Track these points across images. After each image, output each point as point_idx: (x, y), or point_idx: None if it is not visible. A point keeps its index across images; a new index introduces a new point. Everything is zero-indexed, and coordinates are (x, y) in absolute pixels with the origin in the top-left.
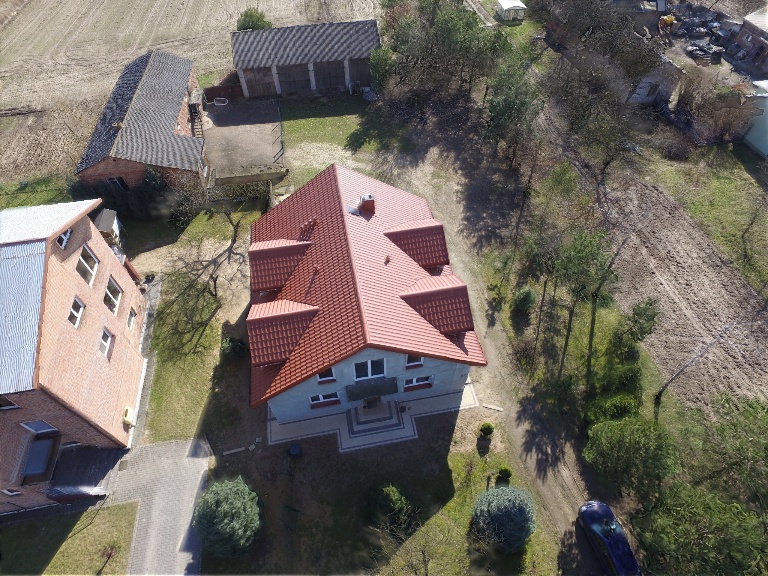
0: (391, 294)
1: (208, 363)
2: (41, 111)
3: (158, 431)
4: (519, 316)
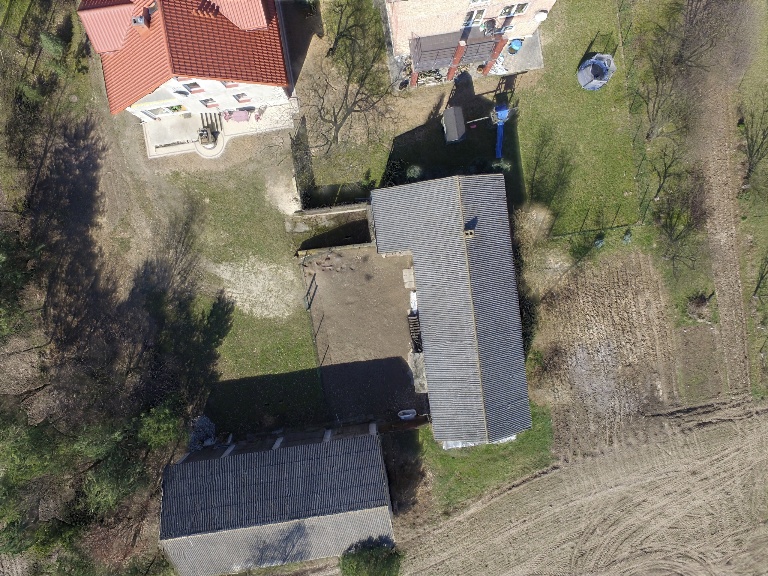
0: None
1: None
2: (658, 416)
3: None
4: (64, 36)
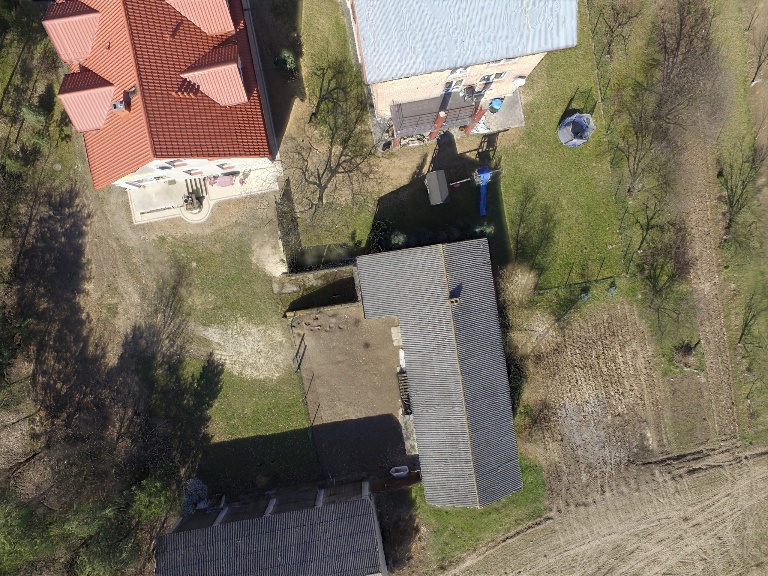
0: (103, 8)
1: (309, 60)
2: (649, 464)
3: (330, 1)
4: (47, 105)
